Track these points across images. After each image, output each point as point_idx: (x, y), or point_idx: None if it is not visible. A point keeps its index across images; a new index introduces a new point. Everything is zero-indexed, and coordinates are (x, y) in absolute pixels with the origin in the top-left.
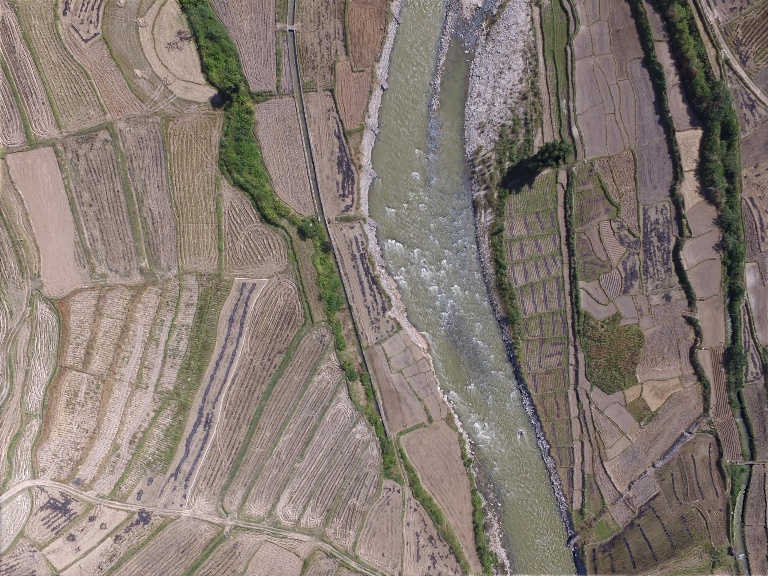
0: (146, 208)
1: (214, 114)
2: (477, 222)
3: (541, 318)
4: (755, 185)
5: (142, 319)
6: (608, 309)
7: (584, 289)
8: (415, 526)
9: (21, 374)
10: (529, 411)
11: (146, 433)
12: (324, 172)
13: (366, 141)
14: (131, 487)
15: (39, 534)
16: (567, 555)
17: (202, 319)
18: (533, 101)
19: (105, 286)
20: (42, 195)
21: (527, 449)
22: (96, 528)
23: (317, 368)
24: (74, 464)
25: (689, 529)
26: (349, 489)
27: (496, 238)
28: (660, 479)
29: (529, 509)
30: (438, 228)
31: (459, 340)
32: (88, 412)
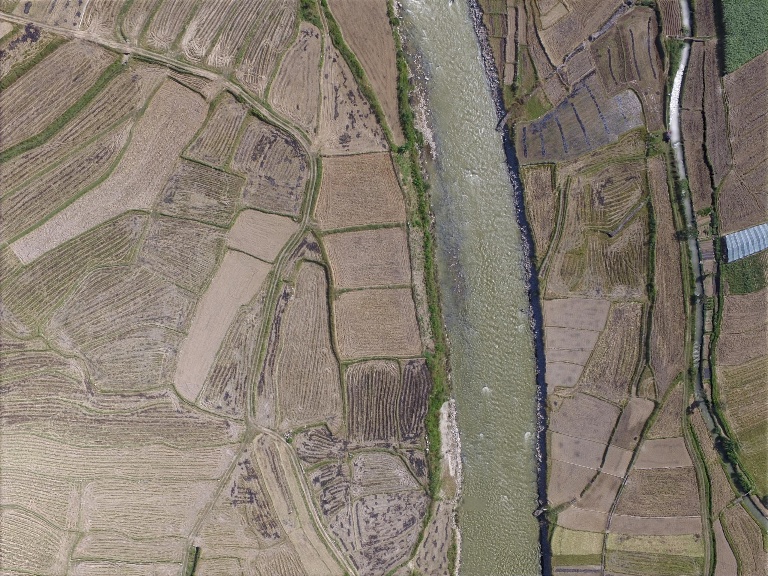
0: None
1: None
2: None
3: None
4: None
5: None
6: None
7: None
8: (334, 79)
9: None
10: None
11: None
12: None
13: None
14: None
15: None
16: (496, 140)
17: None
18: None
19: None
20: None
21: (459, 21)
22: None
23: None
24: None
25: (624, 112)
26: (263, 27)
27: None
28: (596, 55)
29: (458, 86)
30: None
31: None
32: None
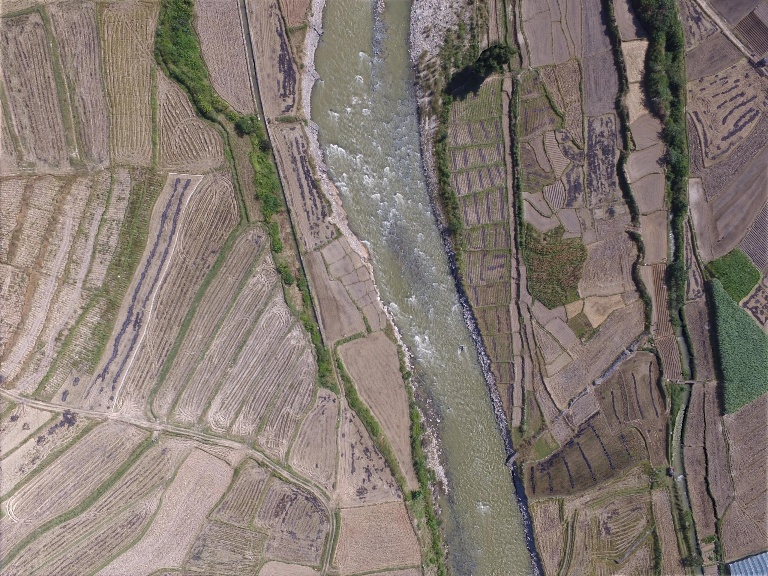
0: (78, 96)
1: (151, 2)
2: (421, 129)
3: (484, 229)
4: (700, 99)
5: (71, 212)
6: (551, 222)
7: (527, 200)
8: (350, 437)
9: None
10: (470, 325)
11: (73, 331)
12: (265, 70)
13: (309, 41)
14: (56, 387)
15: None
16: (506, 474)
17: (134, 214)
18: (479, 6)
19: (33, 175)
20: None
21: (468, 365)
22: (18, 428)
23: (252, 270)
24: None
25: (628, 449)
26: (283, 397)
27: (440, 146)
28: (600, 397)
29: (468, 426)
30: (381, 134)
31: (401, 250)
32: (12, 306)
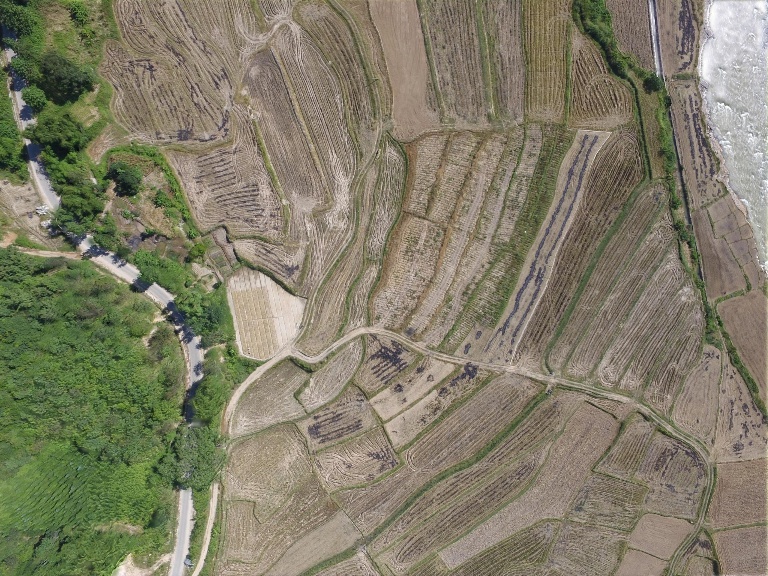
0: (497, 53)
1: None
2: None
3: None
4: None
5: (485, 168)
6: None
7: None
8: (730, 393)
9: (366, 217)
10: None
11: (479, 285)
12: (665, 27)
13: None
14: (459, 340)
15: (369, 383)
16: None
17: (543, 170)
18: None
19: (453, 131)
20: (398, 34)
21: None
22: (423, 380)
23: (651, 226)
24: (408, 313)
25: None
26: (670, 352)
27: None
28: None
29: None
30: None
31: None
32: (427, 260)
